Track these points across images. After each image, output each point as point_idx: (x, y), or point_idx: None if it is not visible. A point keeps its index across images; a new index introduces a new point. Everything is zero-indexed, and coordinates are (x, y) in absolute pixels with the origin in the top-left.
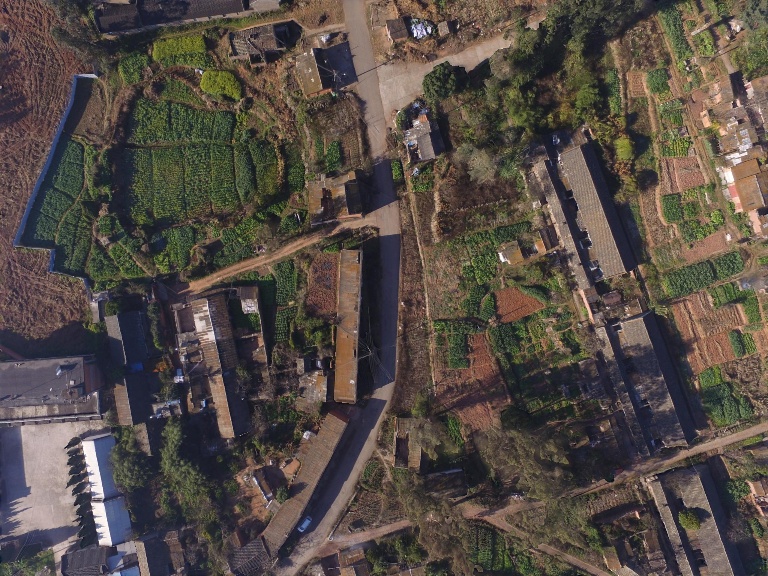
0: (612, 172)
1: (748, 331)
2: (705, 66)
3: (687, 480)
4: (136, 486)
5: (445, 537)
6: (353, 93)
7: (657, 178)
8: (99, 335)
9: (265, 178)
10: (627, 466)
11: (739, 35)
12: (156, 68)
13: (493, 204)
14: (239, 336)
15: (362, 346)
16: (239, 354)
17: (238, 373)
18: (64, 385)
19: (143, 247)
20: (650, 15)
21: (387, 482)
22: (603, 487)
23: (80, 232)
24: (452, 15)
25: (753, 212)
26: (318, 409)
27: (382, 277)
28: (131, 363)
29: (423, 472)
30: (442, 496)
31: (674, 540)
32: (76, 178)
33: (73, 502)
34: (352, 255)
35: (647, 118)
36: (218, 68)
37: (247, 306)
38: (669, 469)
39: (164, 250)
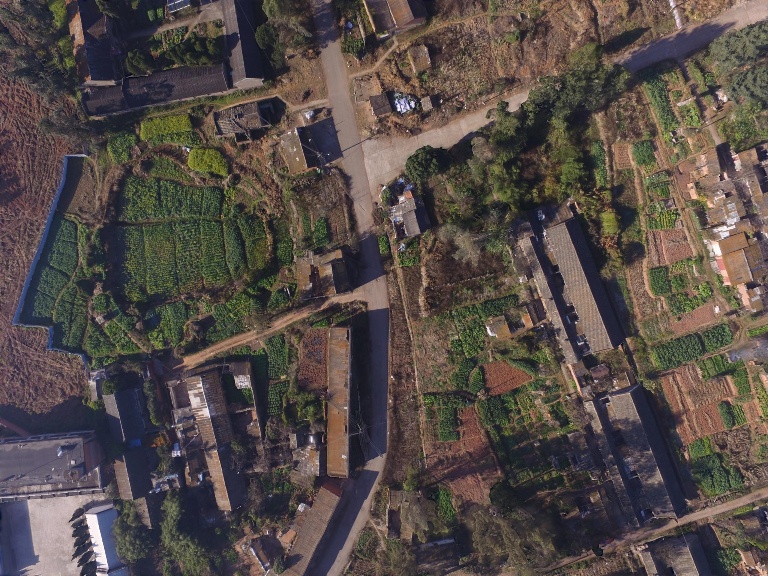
0: (598, 246)
1: (737, 402)
2: (692, 137)
3: (677, 551)
4: (138, 557)
5: None
6: (338, 169)
7: (644, 251)
8: (98, 412)
9: (254, 252)
10: (617, 535)
11: (726, 105)
12: (144, 147)
13: (480, 278)
14: (233, 411)
15: (352, 423)
16: (234, 427)
17: (233, 448)
18: (65, 465)
19: (137, 325)
20: (635, 85)
21: (381, 551)
22: (594, 555)
23: (76, 309)
24: (435, 88)
25: (741, 285)
26: (311, 483)
27: (371, 351)
28: (129, 440)
29: (415, 543)
30: (434, 567)
31: None
32: (71, 256)
33: (80, 569)
34: (341, 333)
35: (633, 190)
36: (205, 145)
37: (240, 381)
38: (659, 538)
39: (158, 326)
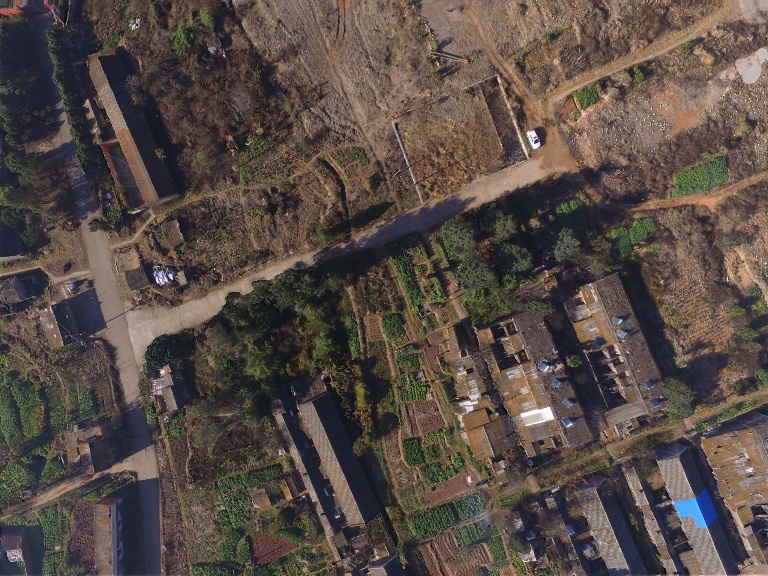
0: (352, 419)
1: (494, 569)
2: (437, 311)
3: None
4: None
5: None
6: (103, 340)
7: (398, 422)
8: None
9: (30, 419)
10: None
11: None
12: None
13: (243, 449)
14: None
15: None
16: None
17: None
18: None
19: None
20: (383, 259)
21: None
22: None
23: None
24: (193, 261)
25: None
26: None
27: (143, 521)
28: None
29: None
30: None
31: None
32: None
33: None
34: (104, 509)
35: (386, 362)
36: None
37: (12, 555)
38: None
39: None
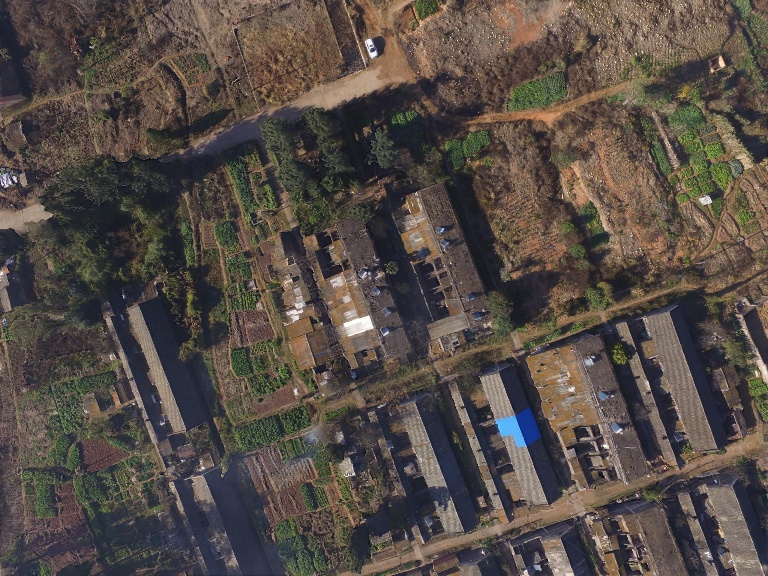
0: (182, 326)
1: (318, 485)
2: (269, 220)
3: None
4: None
5: None
6: None
7: (228, 331)
8: None
9: None
10: None
11: None
12: None
13: (77, 354)
14: None
15: None
16: None
17: None
18: None
19: None
20: (220, 166)
21: None
22: None
23: None
24: (37, 164)
25: None
26: None
27: None
28: None
29: None
30: None
31: None
32: None
33: None
34: None
35: (219, 270)
36: None
37: None
38: None
39: None
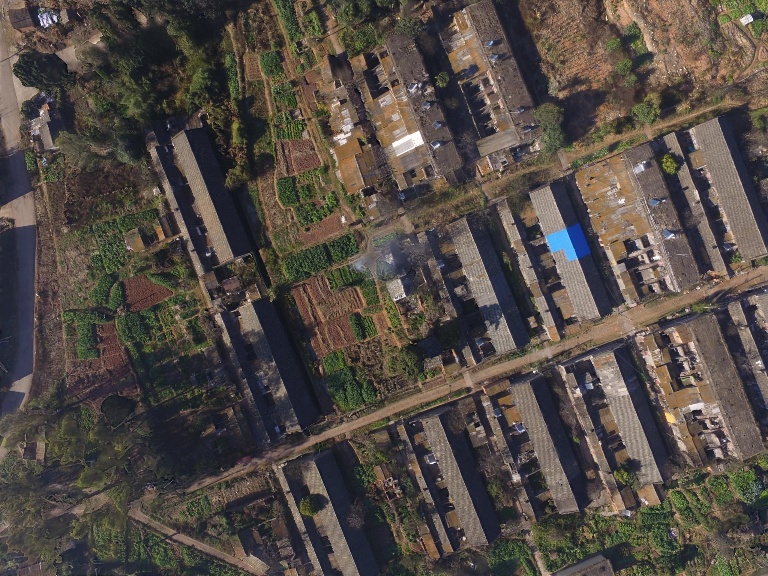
0: (227, 156)
1: (366, 314)
2: (314, 47)
3: (307, 466)
4: None
5: (22, 528)
6: None
7: (274, 161)
8: None
9: None
10: (258, 453)
11: None
12: None
13: (119, 192)
14: None
15: None
16: None
17: None
18: None
19: None
20: None
21: None
22: (235, 475)
23: None
24: (78, 3)
25: None
26: None
27: (18, 269)
28: None
29: None
30: (67, 488)
31: (300, 527)
32: None
33: None
34: None
35: (264, 101)
36: None
37: None
38: (299, 455)
39: None
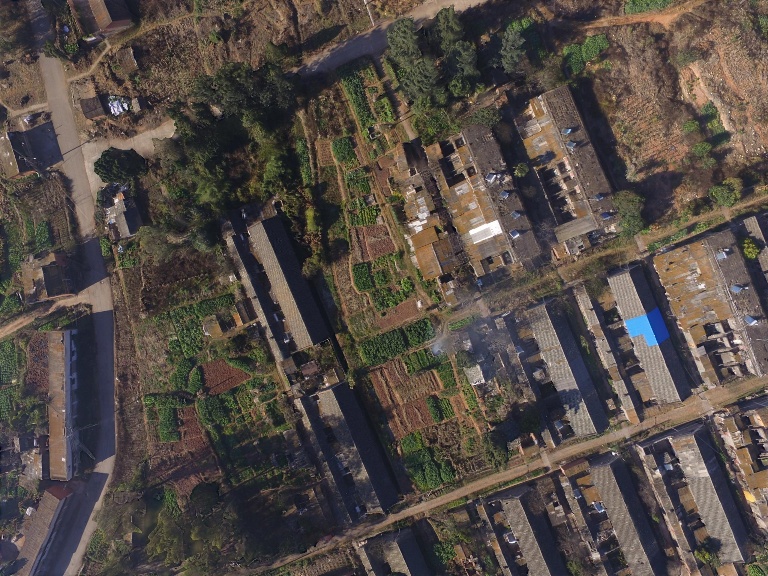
0: (302, 243)
1: (444, 396)
2: (387, 133)
3: (388, 546)
4: None
5: None
6: (59, 172)
7: (348, 247)
8: None
9: None
10: (339, 531)
11: None
12: None
13: (195, 278)
14: None
15: (67, 426)
16: None
17: None
18: None
19: None
20: (334, 83)
21: None
22: (316, 552)
23: None
24: (147, 90)
25: (437, 279)
26: (36, 486)
27: (97, 353)
28: None
29: (138, 545)
30: (155, 568)
31: None
32: None
33: None
34: (57, 336)
35: (337, 187)
36: None
37: None
38: (379, 533)
39: None
